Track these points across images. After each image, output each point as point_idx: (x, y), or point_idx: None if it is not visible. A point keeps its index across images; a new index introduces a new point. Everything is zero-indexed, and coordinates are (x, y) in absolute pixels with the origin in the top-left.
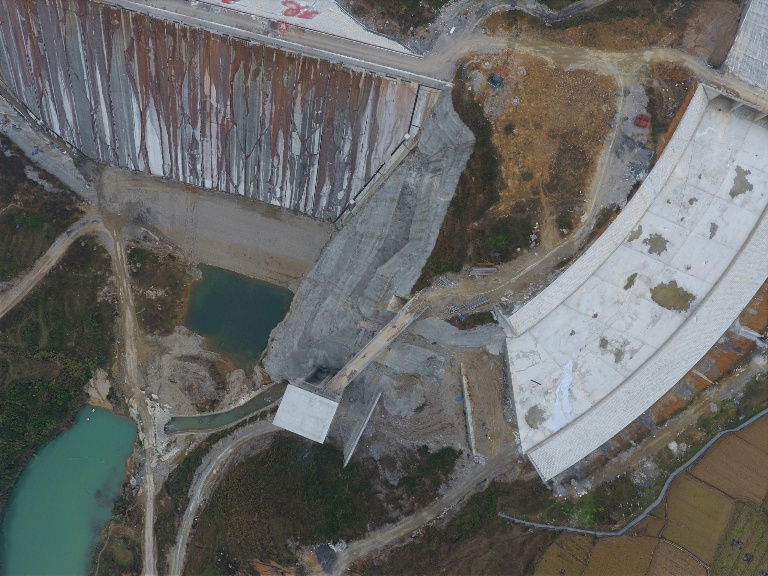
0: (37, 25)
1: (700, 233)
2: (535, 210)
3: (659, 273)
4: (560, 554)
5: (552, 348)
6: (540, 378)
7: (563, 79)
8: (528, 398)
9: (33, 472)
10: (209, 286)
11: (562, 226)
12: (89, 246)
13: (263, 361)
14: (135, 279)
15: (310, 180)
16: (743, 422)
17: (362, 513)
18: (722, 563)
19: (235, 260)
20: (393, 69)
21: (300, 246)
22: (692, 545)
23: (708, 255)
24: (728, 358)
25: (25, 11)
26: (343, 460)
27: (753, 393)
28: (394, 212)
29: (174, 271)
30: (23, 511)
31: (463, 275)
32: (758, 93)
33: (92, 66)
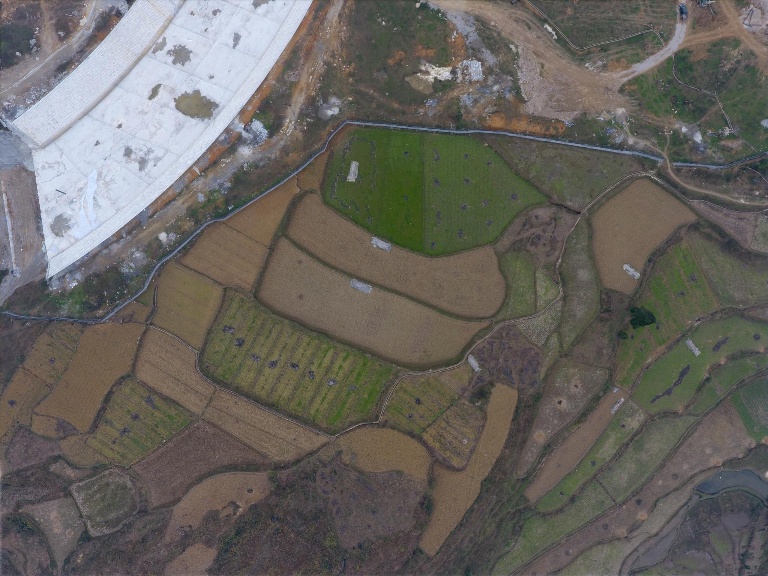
0: None
1: (223, 43)
2: (35, 15)
3: (183, 83)
4: (50, 343)
5: (77, 158)
6: (65, 188)
7: None
8: (53, 207)
9: None
10: None
11: (58, 29)
12: None
13: None
14: None
15: None
16: None
17: None
18: (214, 348)
19: None
20: None
21: None
22: (181, 331)
23: (231, 64)
24: (219, 151)
25: None
26: None
27: (242, 183)
28: None
29: None
30: None
31: None
32: None
33: None
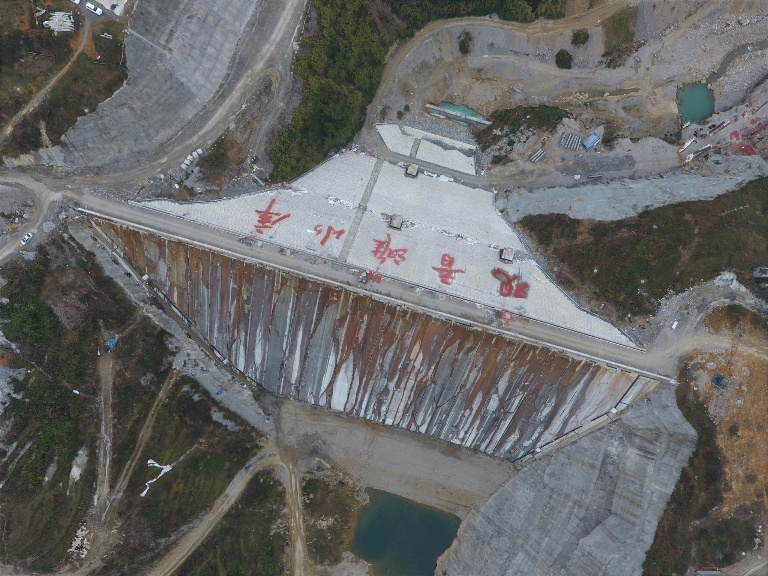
0: (248, 292)
1: None
2: (759, 513)
3: None
4: None
5: None
6: None
7: None
8: None
9: None
10: (375, 509)
11: None
12: (267, 482)
13: None
14: (307, 510)
15: (499, 429)
16: None
17: None
18: None
19: (405, 487)
20: (618, 364)
21: (476, 482)
22: None
23: None
24: None
25: (239, 281)
26: None
27: None
28: (596, 481)
29: (343, 497)
30: None
31: None
32: None
33: (296, 326)
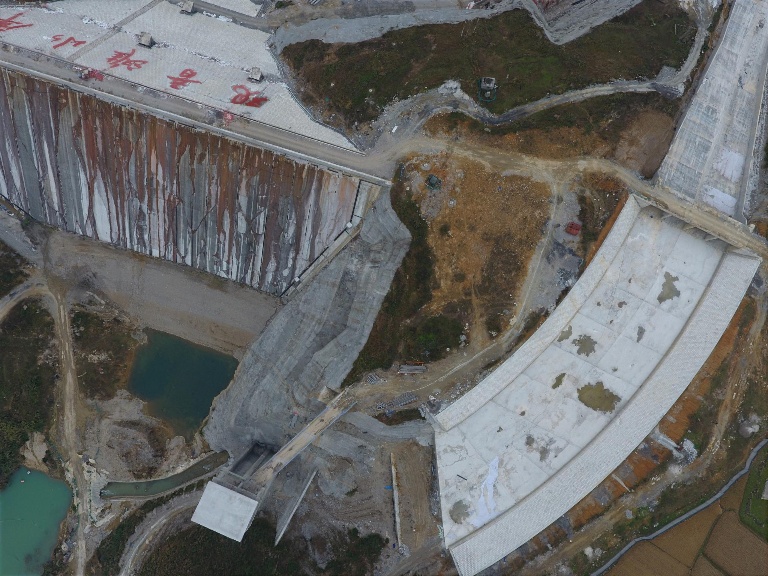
0: None
1: (628, 336)
2: (466, 311)
3: (587, 374)
4: None
5: (479, 444)
6: (466, 473)
7: (499, 184)
8: (453, 493)
9: None
10: (154, 350)
11: (491, 329)
12: (32, 309)
13: (203, 430)
14: (78, 343)
15: (256, 257)
16: (657, 529)
17: None
18: None
19: (181, 326)
20: (334, 165)
21: (245, 318)
22: None
23: (634, 358)
24: (645, 466)
25: None
26: (275, 537)
27: (668, 501)
28: (334, 297)
29: (119, 335)
30: None
31: (392, 372)
32: (686, 206)
33: (40, 138)
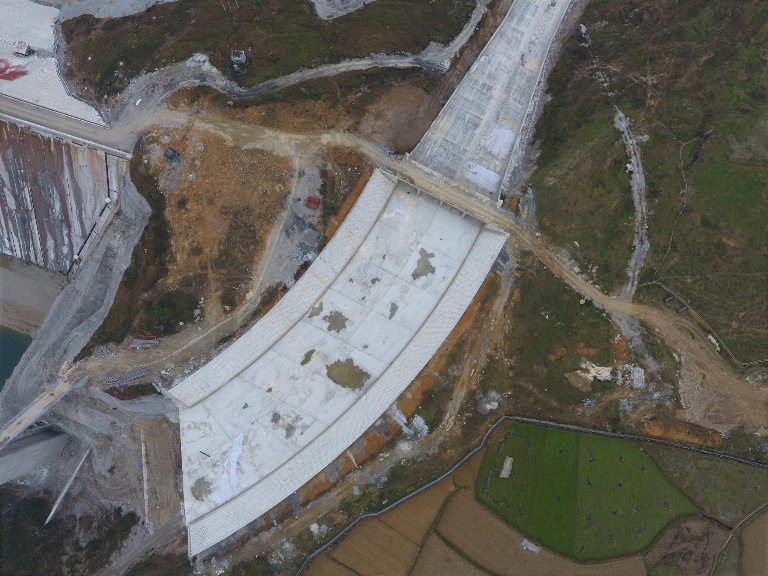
0: None
1: (380, 313)
2: (201, 285)
3: (336, 350)
4: None
5: (224, 420)
6: (210, 450)
7: (239, 157)
8: (196, 469)
9: None
10: None
11: (224, 303)
12: None
13: None
14: None
15: (33, 233)
16: (387, 506)
17: (38, 575)
18: None
19: None
20: (74, 137)
21: (34, 296)
22: None
23: (386, 335)
24: (377, 442)
25: None
26: (48, 516)
27: (398, 478)
28: (95, 273)
29: None
30: None
31: (124, 346)
32: (433, 181)
33: None
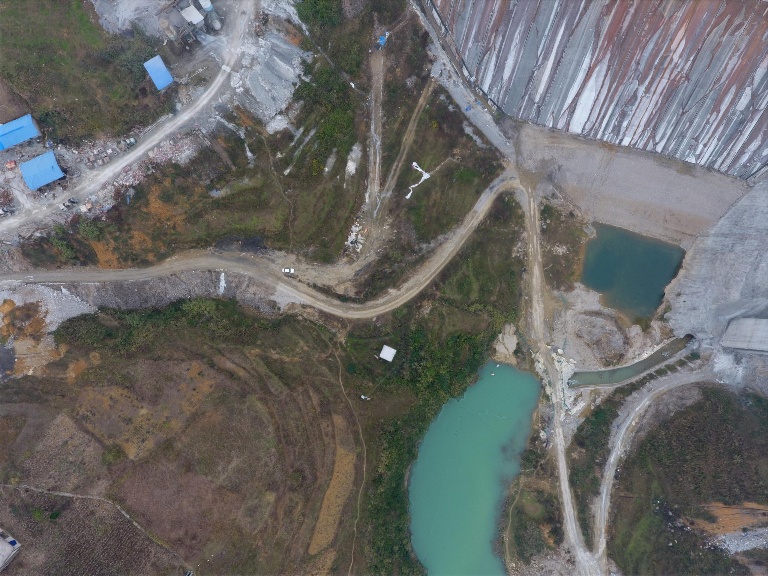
0: None
1: None
2: None
3: None
4: None
5: None
6: None
7: None
8: None
9: (436, 428)
10: (600, 244)
11: None
12: (510, 202)
13: (667, 316)
14: (544, 235)
15: (741, 136)
16: None
17: None
18: None
19: (633, 218)
20: None
21: (708, 203)
22: None
23: None
24: None
25: None
26: None
27: None
28: None
29: (573, 229)
30: (428, 467)
31: None
32: None
33: (559, 21)
